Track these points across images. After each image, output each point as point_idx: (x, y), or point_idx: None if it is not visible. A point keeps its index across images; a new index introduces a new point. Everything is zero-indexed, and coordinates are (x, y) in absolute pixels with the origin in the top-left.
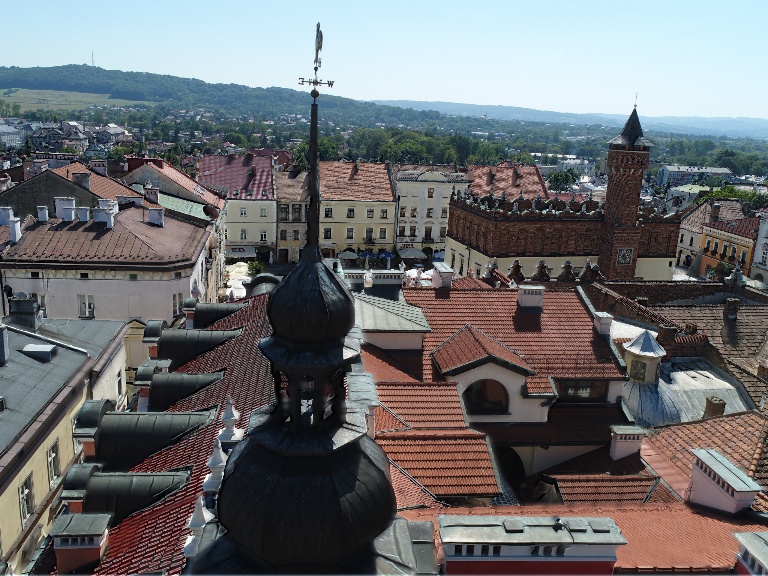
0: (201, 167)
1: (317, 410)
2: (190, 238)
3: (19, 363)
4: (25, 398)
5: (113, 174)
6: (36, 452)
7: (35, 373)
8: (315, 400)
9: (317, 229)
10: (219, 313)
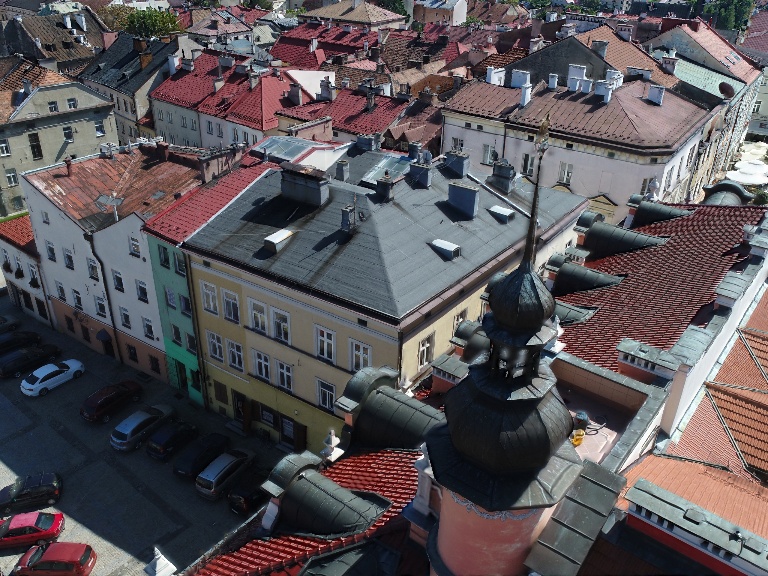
0: (753, 25)
1: (508, 370)
2: (684, 121)
3: (483, 220)
4: (477, 250)
5: (647, 33)
6: (475, 293)
7: (492, 231)
8: (507, 363)
9: (531, 250)
10: (660, 215)
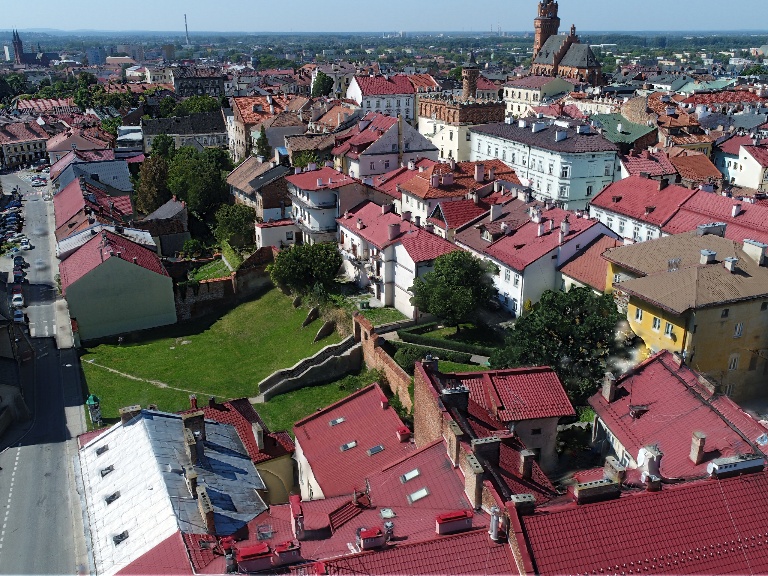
0: None
1: None
2: None
3: None
4: None
5: None
6: None
7: None
8: None
9: None
10: None
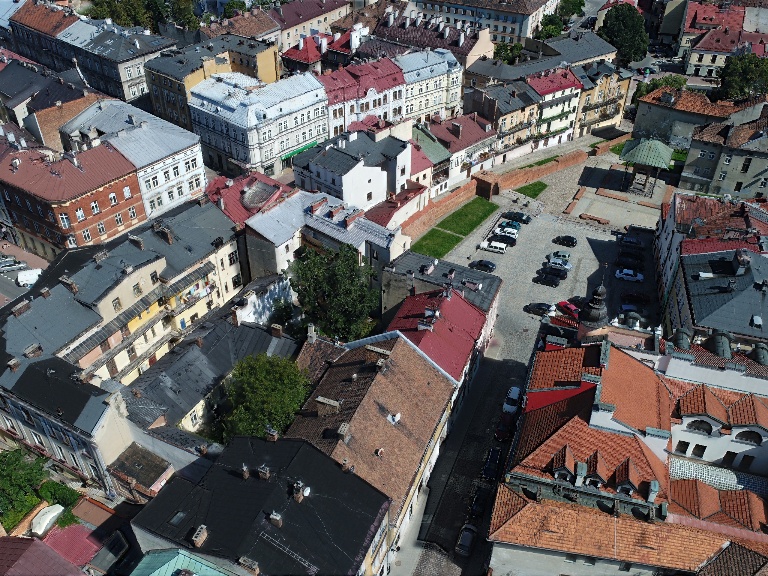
0: None
1: None
2: None
3: None
4: None
5: None
6: None
7: None
8: None
9: None
10: None
